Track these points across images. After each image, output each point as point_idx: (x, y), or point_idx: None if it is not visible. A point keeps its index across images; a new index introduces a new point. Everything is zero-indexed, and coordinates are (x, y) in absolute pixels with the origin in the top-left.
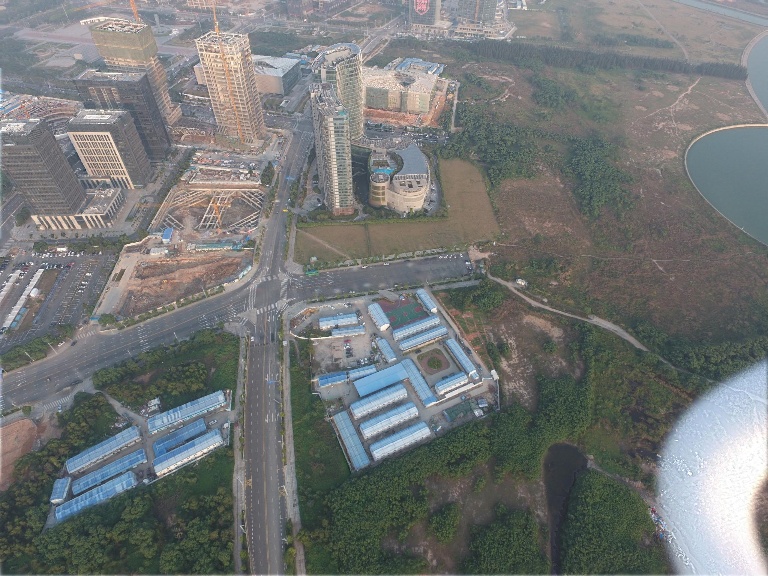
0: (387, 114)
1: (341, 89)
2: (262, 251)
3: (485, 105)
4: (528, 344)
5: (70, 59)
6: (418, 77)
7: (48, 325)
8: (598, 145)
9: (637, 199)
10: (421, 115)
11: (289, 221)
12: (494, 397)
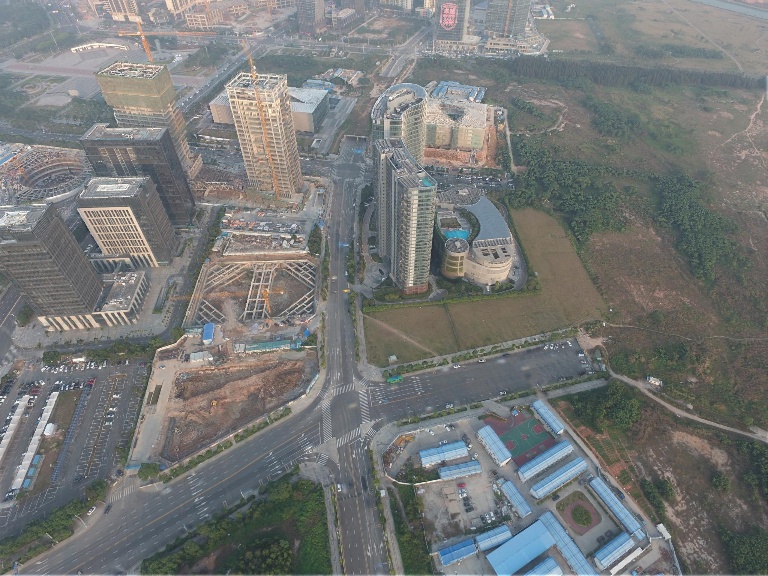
0: (435, 152)
1: (404, 140)
2: (327, 349)
3: (542, 136)
4: (691, 478)
5: (64, 96)
6: (467, 108)
7: (71, 480)
8: (686, 184)
9: (752, 254)
10: (474, 152)
11: (354, 305)
12: (672, 568)
